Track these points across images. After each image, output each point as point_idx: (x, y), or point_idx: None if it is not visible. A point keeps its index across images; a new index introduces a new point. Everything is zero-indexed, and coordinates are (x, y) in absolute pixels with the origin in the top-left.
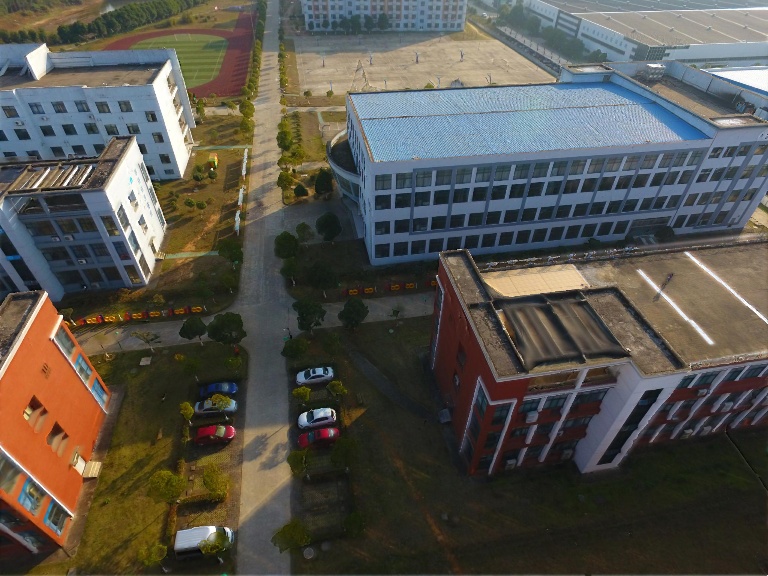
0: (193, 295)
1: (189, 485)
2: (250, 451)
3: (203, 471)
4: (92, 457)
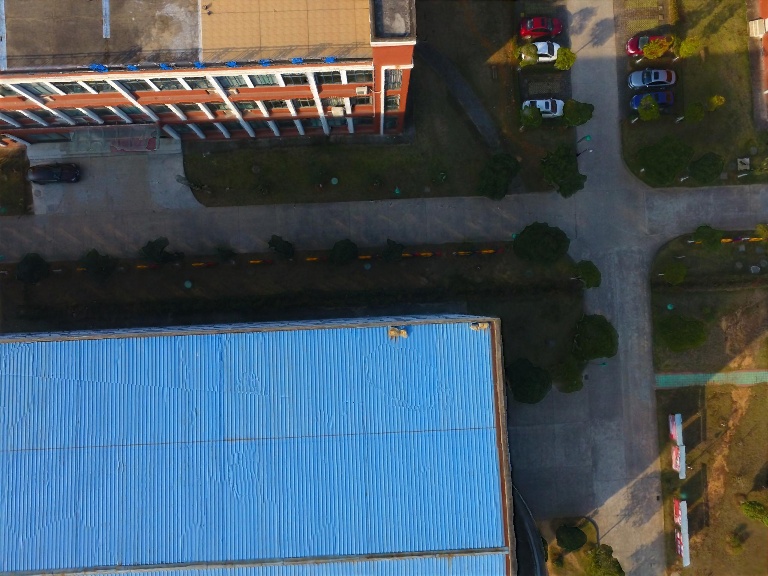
0: (713, 275)
1: (661, 1)
2: (608, 29)
3: (651, 13)
4: (761, 43)
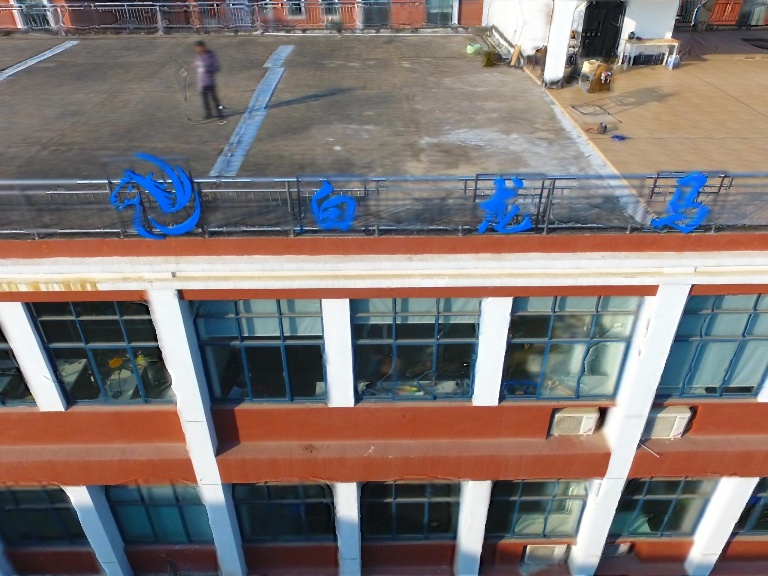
0: None
1: None
2: None
3: None
4: None
